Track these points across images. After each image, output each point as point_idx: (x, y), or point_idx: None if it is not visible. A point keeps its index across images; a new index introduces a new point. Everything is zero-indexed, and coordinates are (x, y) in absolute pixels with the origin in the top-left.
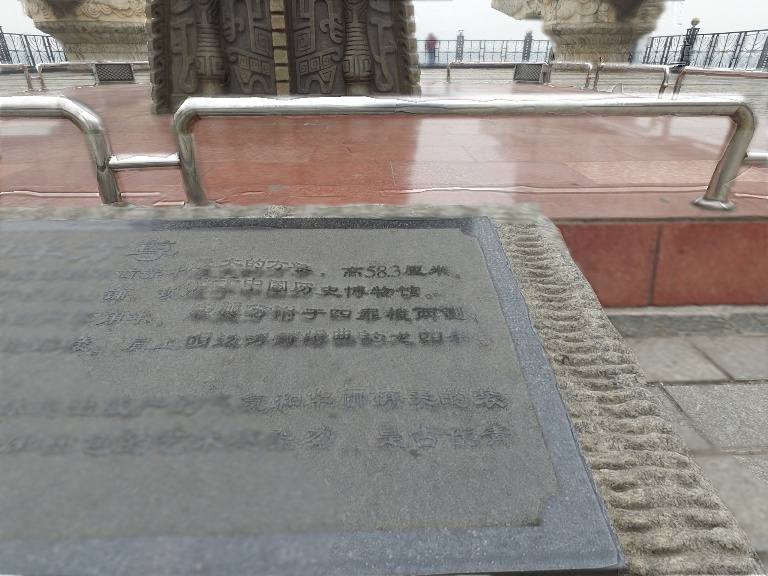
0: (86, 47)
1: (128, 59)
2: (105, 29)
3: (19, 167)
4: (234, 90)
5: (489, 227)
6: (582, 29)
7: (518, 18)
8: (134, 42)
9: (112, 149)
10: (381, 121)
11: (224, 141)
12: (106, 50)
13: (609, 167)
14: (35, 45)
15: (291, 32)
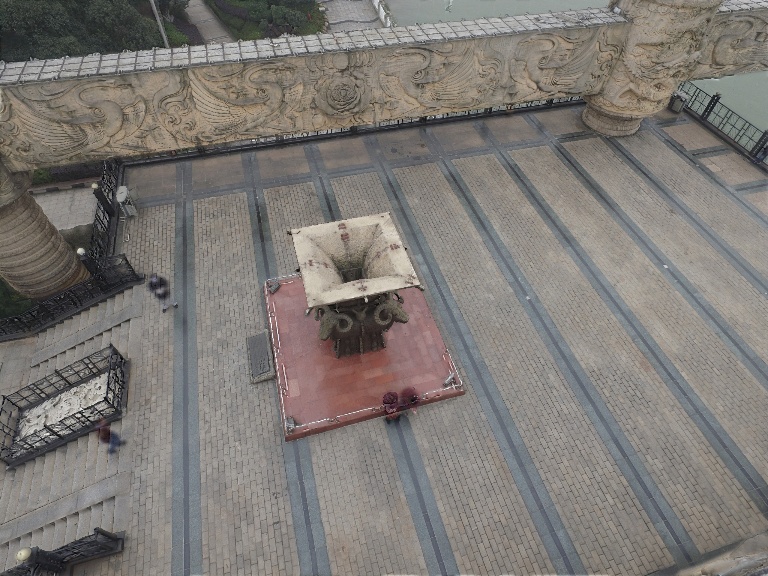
0: (592, 112)
1: (612, 128)
2: (603, 112)
3: None
4: None
5: (269, 371)
6: None
7: None
8: (624, 119)
9: None
10: (326, 354)
11: None
12: (600, 119)
13: (295, 382)
14: None
15: None
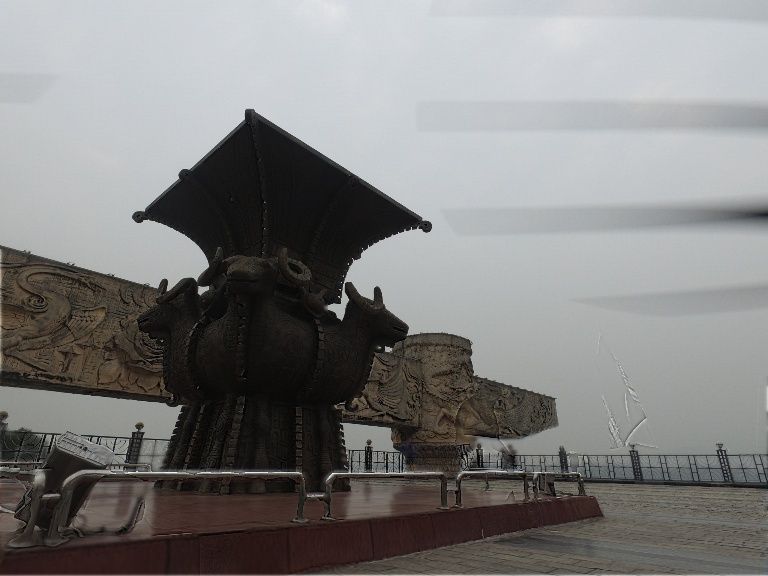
0: (416, 460)
1: (443, 469)
2: (429, 447)
3: None
4: None
5: None
6: None
7: None
8: (450, 457)
9: None
10: None
11: None
12: (428, 462)
13: None
14: (392, 459)
15: None
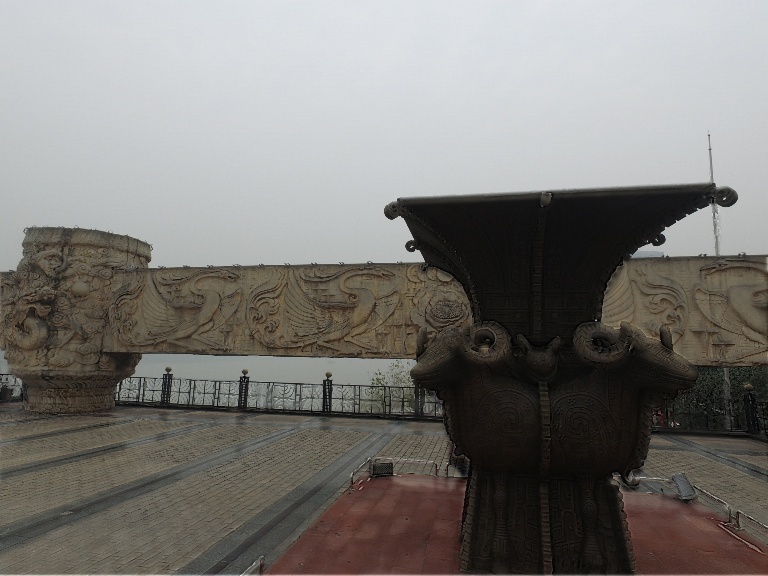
0: None
1: None
2: None
3: None
4: None
5: None
6: (83, 376)
7: None
8: None
9: None
10: None
11: None
12: None
13: None
14: None
15: None
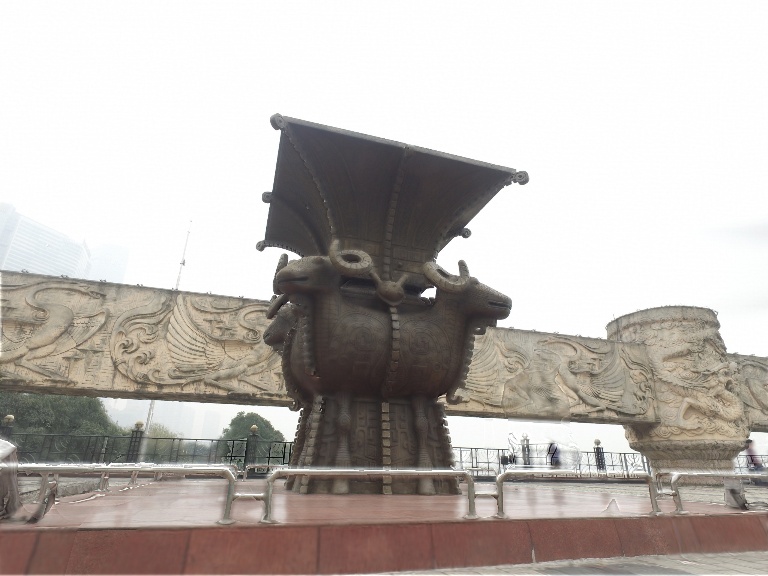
0: (663, 462)
1: None
2: (676, 447)
3: None
4: None
5: None
6: None
7: None
8: (711, 458)
9: (107, 475)
10: None
11: None
12: (680, 465)
13: None
14: (633, 461)
15: None
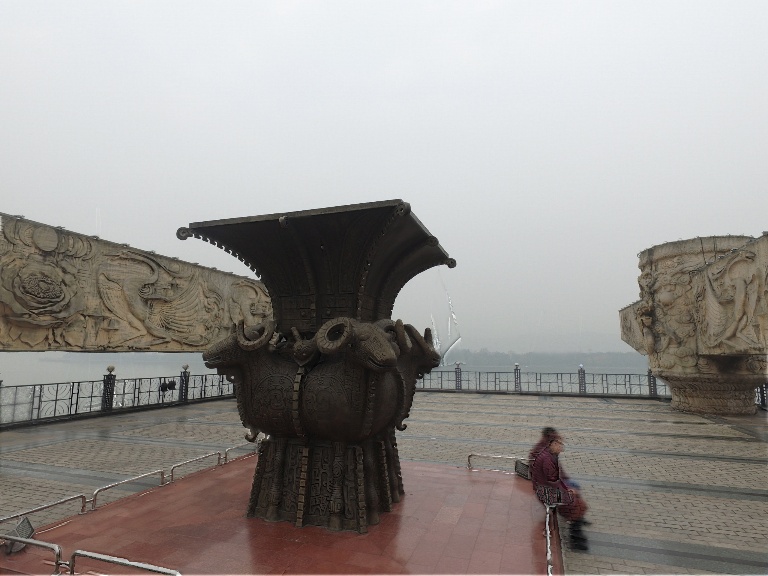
0: None
1: None
2: None
3: (171, 568)
4: (282, 508)
5: None
6: (686, 378)
7: (642, 353)
8: None
9: None
10: (333, 542)
11: (247, 556)
12: None
13: None
14: None
15: (310, 485)
